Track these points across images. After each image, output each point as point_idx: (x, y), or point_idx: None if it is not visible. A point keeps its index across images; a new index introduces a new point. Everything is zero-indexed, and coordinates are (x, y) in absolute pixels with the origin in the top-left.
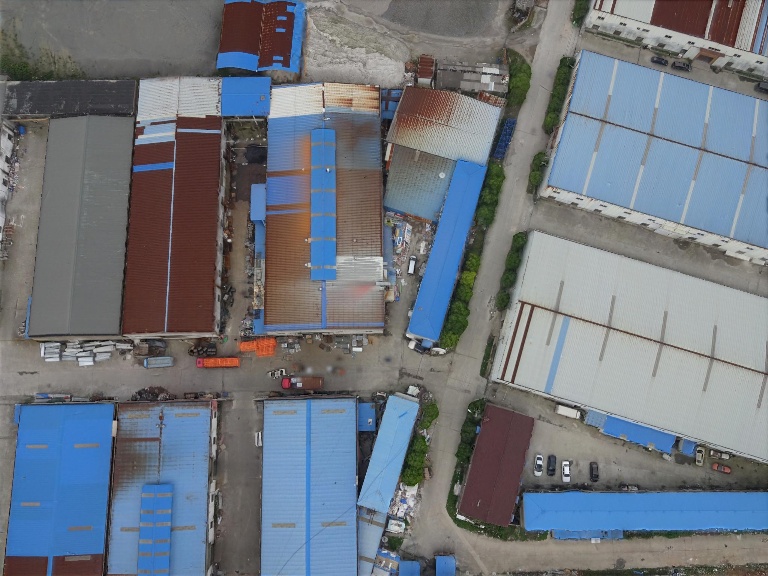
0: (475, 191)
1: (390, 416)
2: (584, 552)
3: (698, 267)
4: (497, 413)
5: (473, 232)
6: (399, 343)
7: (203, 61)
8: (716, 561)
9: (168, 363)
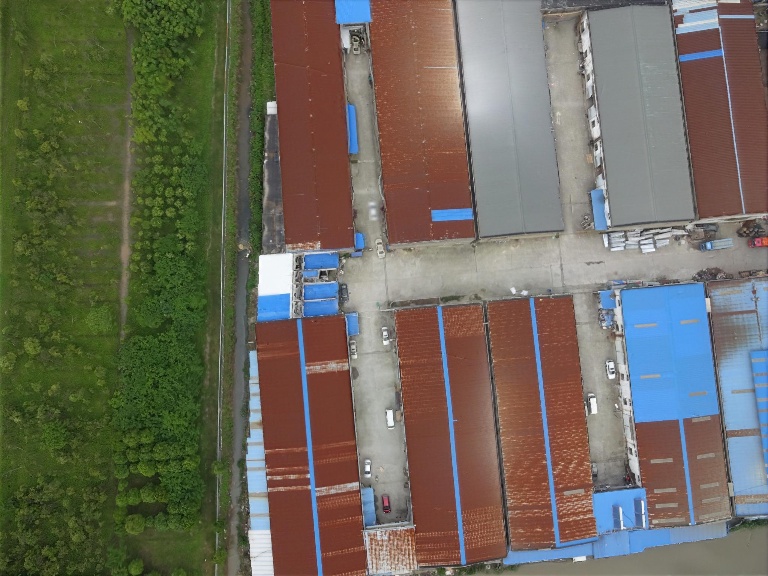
0: None
1: None
2: None
3: None
4: None
5: None
6: None
7: None
8: None
9: (731, 244)
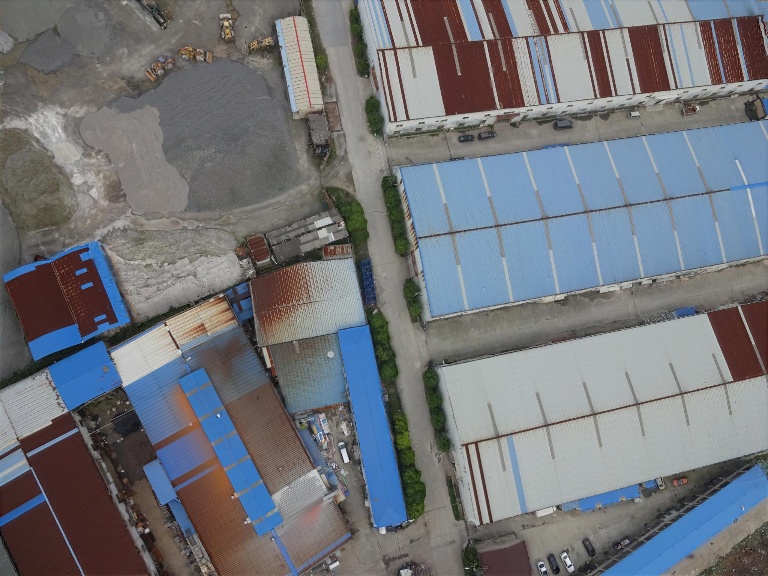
0: (370, 356)
1: None
2: None
3: (584, 315)
4: (492, 557)
5: None
6: (369, 534)
7: (12, 355)
8: (710, 561)
9: None
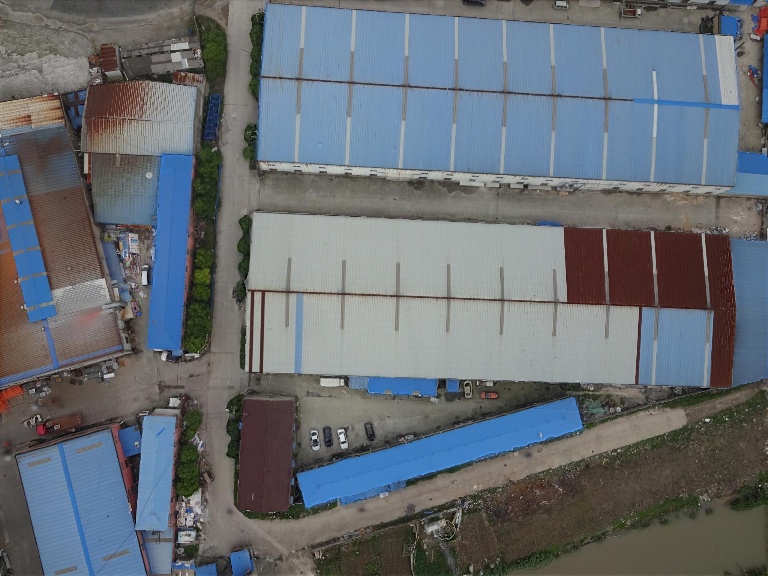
0: (185, 185)
1: (148, 437)
2: (375, 508)
3: (436, 204)
4: (253, 406)
5: (203, 225)
6: (152, 358)
7: None
8: (498, 482)
9: None
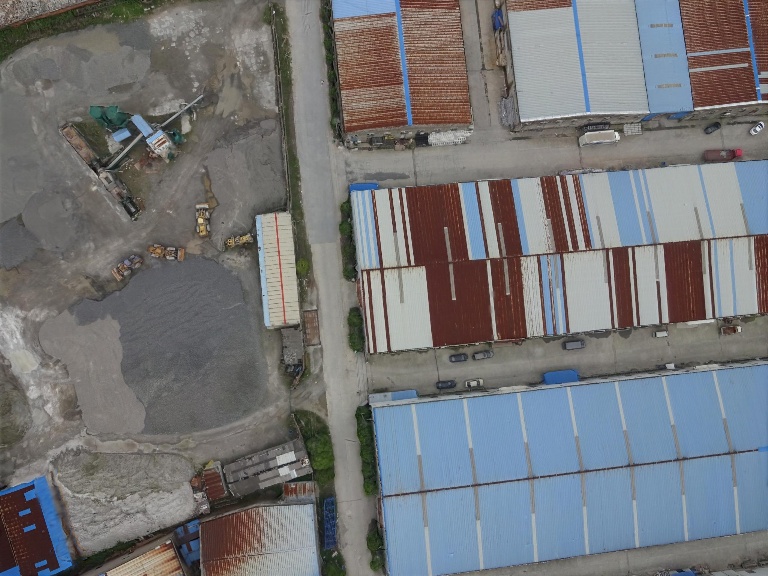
0: None
1: None
2: None
3: (567, 569)
4: None
5: None
6: None
7: None
8: None
9: None
